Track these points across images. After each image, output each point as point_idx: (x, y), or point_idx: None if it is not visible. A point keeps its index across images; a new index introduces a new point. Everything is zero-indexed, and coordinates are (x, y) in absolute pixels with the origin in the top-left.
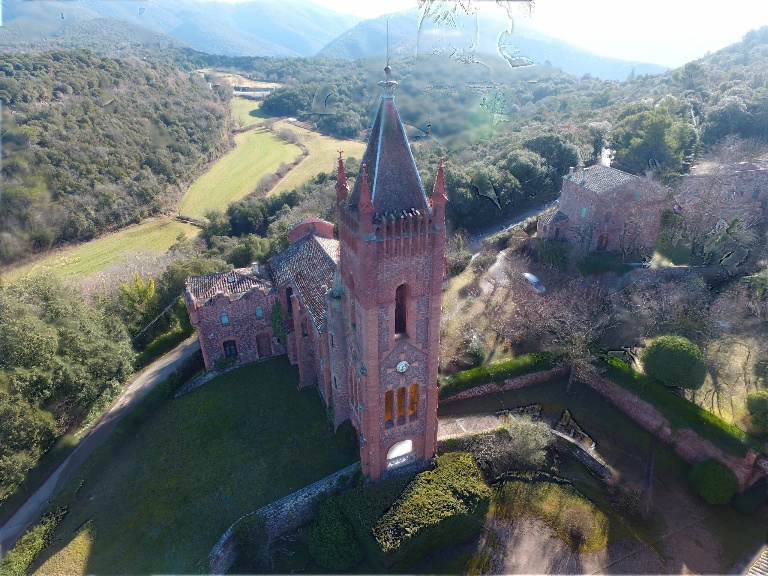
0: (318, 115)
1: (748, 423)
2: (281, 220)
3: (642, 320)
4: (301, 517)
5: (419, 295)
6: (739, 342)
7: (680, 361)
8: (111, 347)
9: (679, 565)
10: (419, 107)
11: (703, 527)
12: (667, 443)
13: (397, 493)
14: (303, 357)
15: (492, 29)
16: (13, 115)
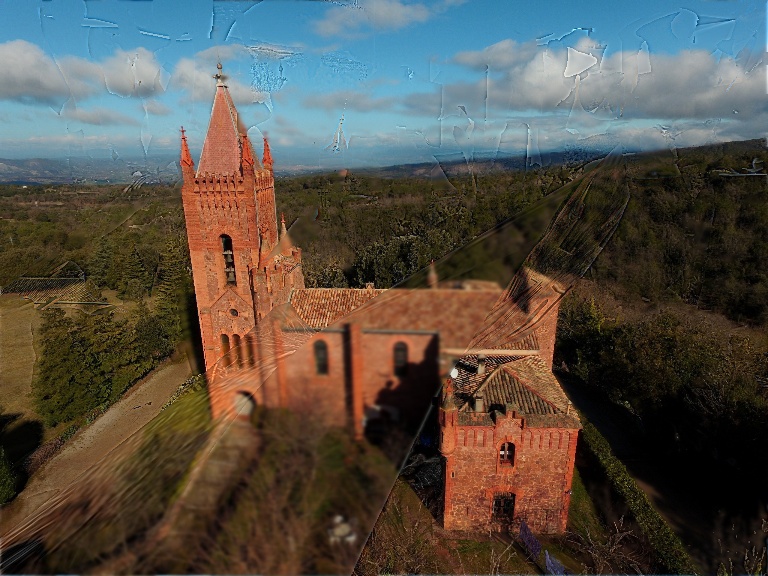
0: None
1: None
2: None
3: None
4: None
5: None
6: None
7: None
8: None
9: None
10: (361, 94)
11: None
12: None
13: None
14: None
15: None
16: (664, 143)
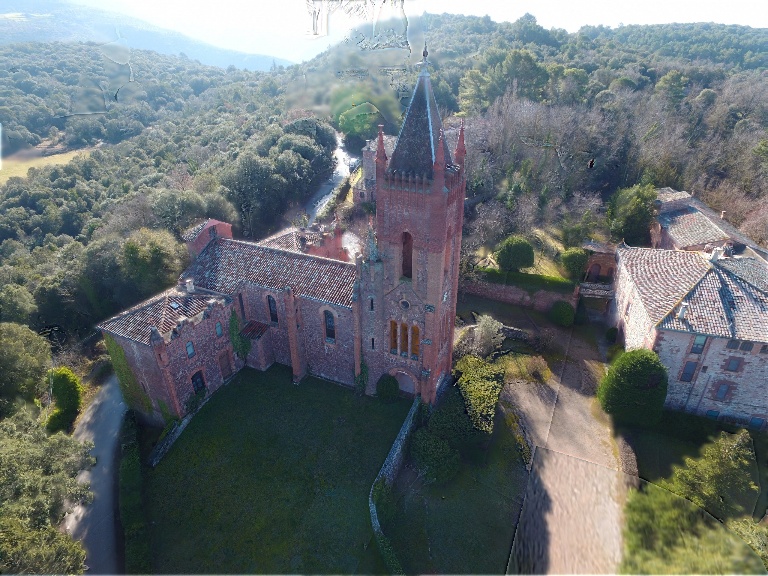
0: (80, 116)
1: (564, 273)
2: (128, 241)
3: (496, 232)
4: (398, 466)
5: (453, 234)
6: (536, 231)
7: (524, 250)
8: (67, 439)
9: (583, 361)
10: (341, 90)
11: (575, 339)
12: (529, 306)
13: (460, 399)
14: (298, 349)
15: (408, 22)
16: None
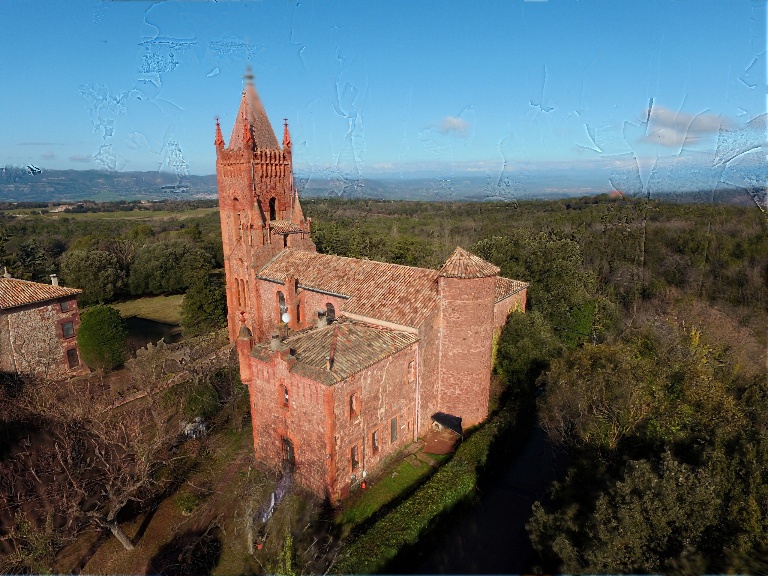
0: None
1: None
2: None
3: None
4: None
5: None
6: None
7: None
8: None
9: None
10: (258, 71)
11: None
12: None
13: None
14: None
15: None
16: None
